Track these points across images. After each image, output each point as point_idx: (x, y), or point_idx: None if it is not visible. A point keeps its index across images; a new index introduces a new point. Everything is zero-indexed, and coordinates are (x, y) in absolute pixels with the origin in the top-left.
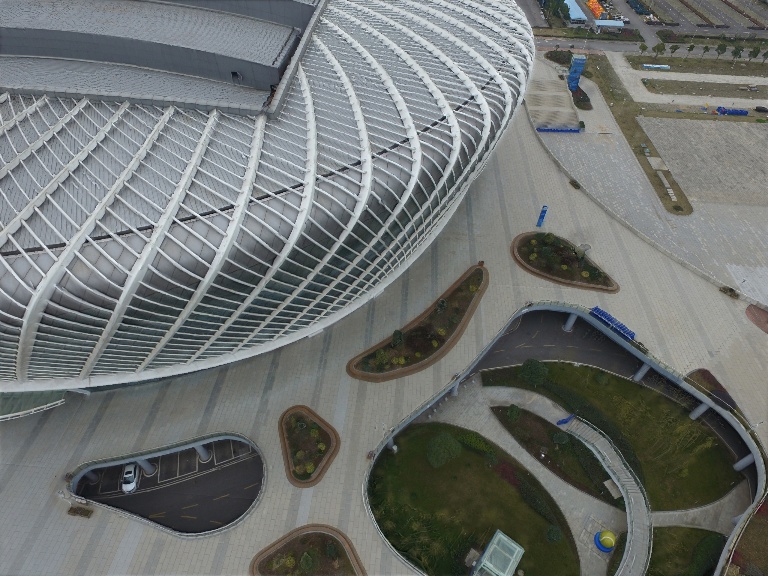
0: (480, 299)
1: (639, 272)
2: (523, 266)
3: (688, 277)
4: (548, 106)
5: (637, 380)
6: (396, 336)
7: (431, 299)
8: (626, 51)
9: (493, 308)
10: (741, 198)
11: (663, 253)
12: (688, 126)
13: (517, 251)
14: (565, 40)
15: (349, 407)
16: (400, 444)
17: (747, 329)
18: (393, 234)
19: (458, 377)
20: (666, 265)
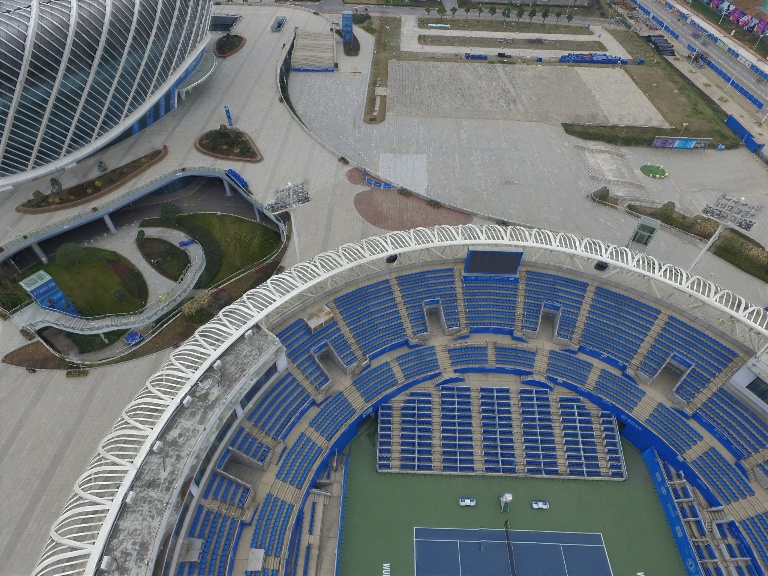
0: (149, 168)
1: (286, 151)
2: (197, 149)
3: (321, 153)
4: (314, 52)
5: (258, 221)
6: (51, 182)
7: (111, 169)
8: (421, 15)
9: (155, 173)
10: (429, 112)
11: (315, 140)
12: (427, 66)
13: (199, 140)
14: (373, 7)
15: (4, 228)
16: (53, 259)
17: (338, 181)
18: (3, 90)
19: (96, 210)
20: (311, 147)
